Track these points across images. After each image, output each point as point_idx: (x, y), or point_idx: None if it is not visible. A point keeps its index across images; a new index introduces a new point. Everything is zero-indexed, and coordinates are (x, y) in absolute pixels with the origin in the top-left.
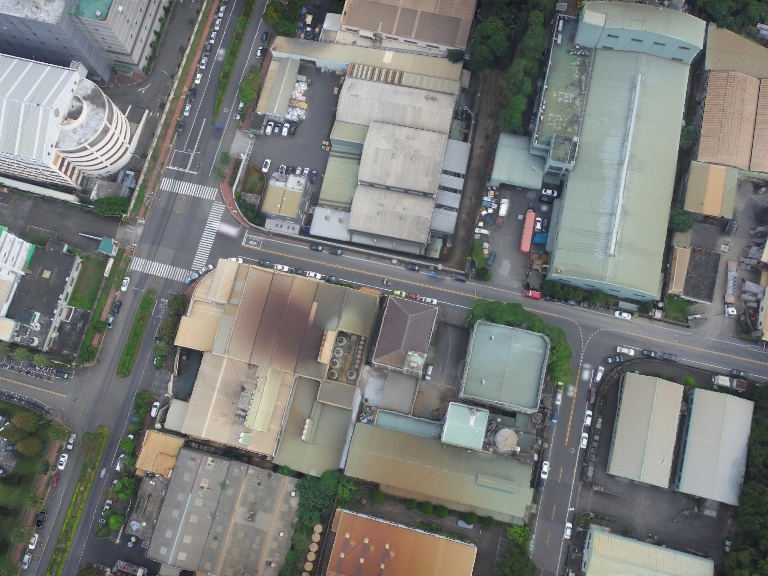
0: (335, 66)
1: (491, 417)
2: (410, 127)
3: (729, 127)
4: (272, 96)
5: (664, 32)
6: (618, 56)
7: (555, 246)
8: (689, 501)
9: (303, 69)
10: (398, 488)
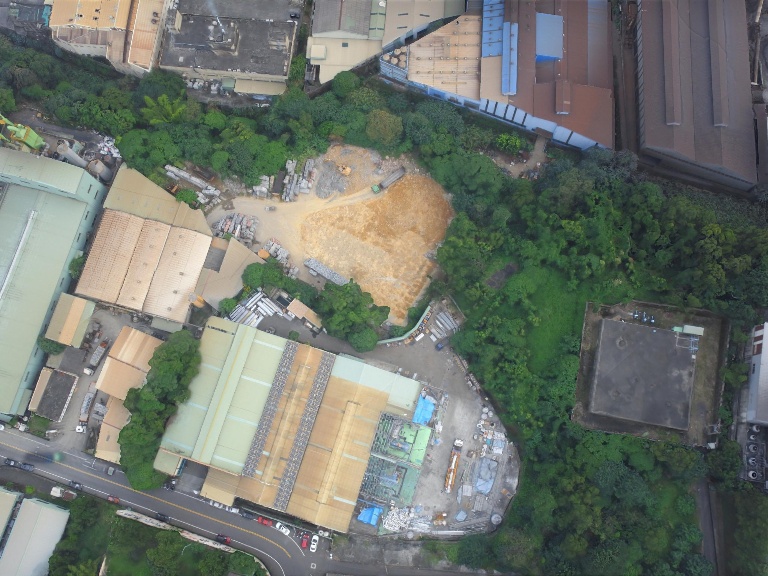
0: None
1: None
2: None
3: (103, 263)
4: None
5: (36, 179)
6: (24, 192)
7: None
8: None
9: None
10: None
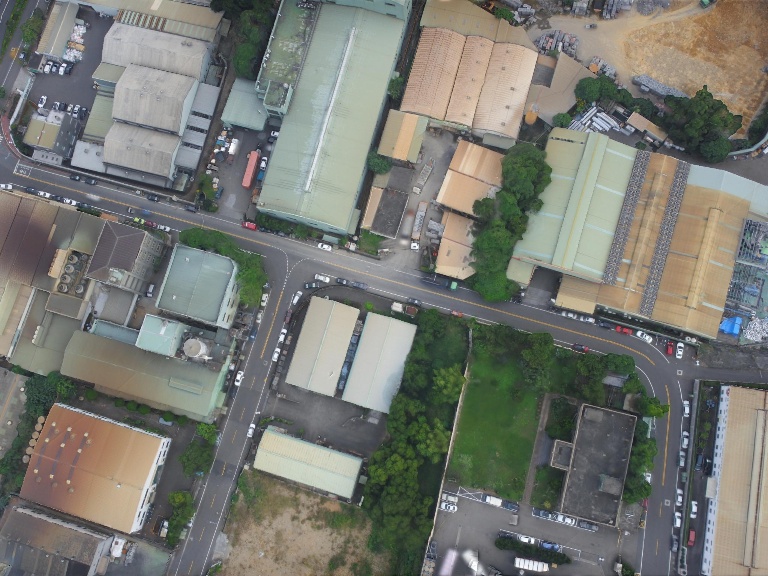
0: (110, 11)
1: (193, 330)
2: (163, 70)
3: (429, 79)
4: (51, 37)
5: None
6: (340, 10)
7: (264, 182)
8: (358, 410)
9: (84, 13)
10: (109, 388)
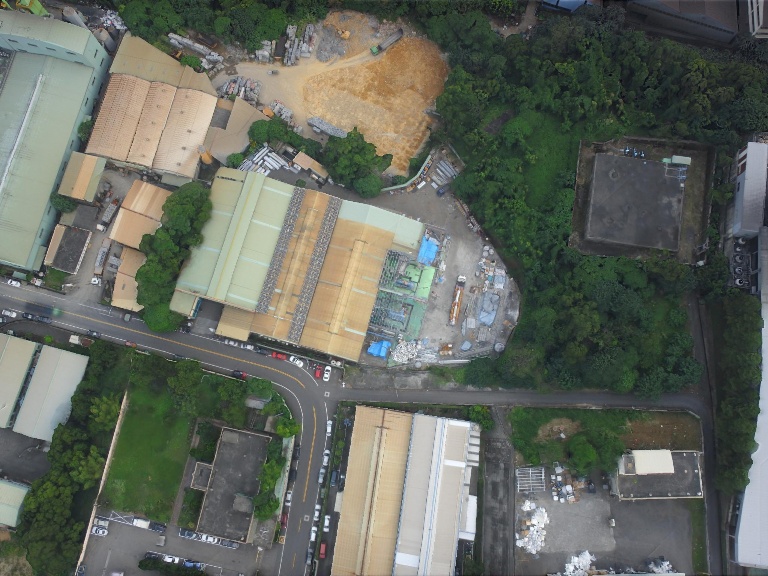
0: None
1: None
2: None
3: (112, 123)
4: None
5: (44, 39)
6: (31, 58)
7: None
8: (35, 440)
9: None
10: None
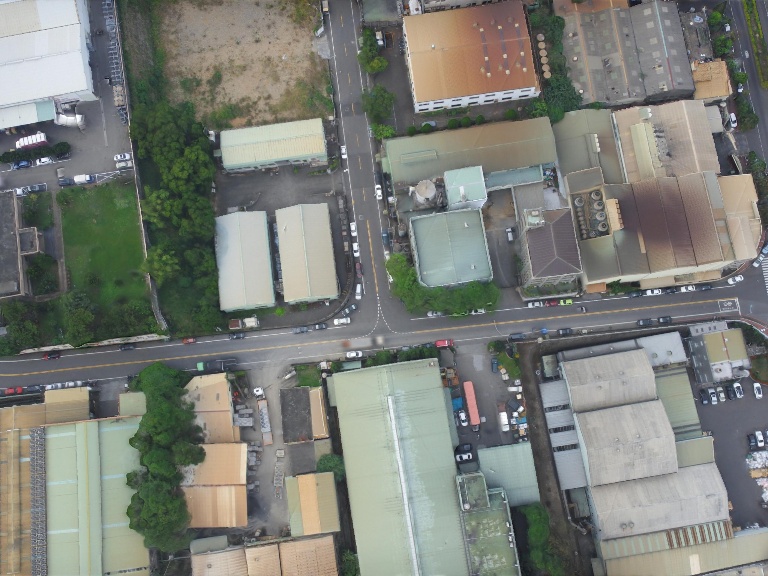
0: None
1: None
2: None
3: None
4: None
5: None
6: None
7: None
8: None
9: None
10: None
